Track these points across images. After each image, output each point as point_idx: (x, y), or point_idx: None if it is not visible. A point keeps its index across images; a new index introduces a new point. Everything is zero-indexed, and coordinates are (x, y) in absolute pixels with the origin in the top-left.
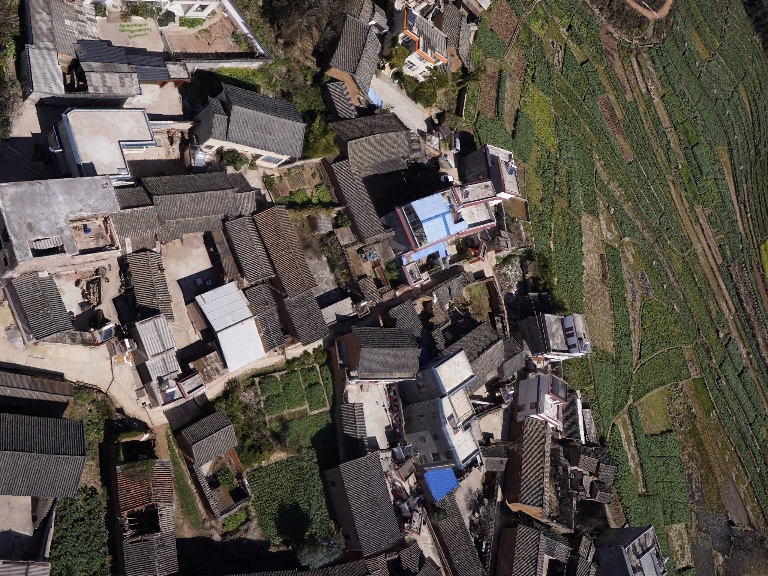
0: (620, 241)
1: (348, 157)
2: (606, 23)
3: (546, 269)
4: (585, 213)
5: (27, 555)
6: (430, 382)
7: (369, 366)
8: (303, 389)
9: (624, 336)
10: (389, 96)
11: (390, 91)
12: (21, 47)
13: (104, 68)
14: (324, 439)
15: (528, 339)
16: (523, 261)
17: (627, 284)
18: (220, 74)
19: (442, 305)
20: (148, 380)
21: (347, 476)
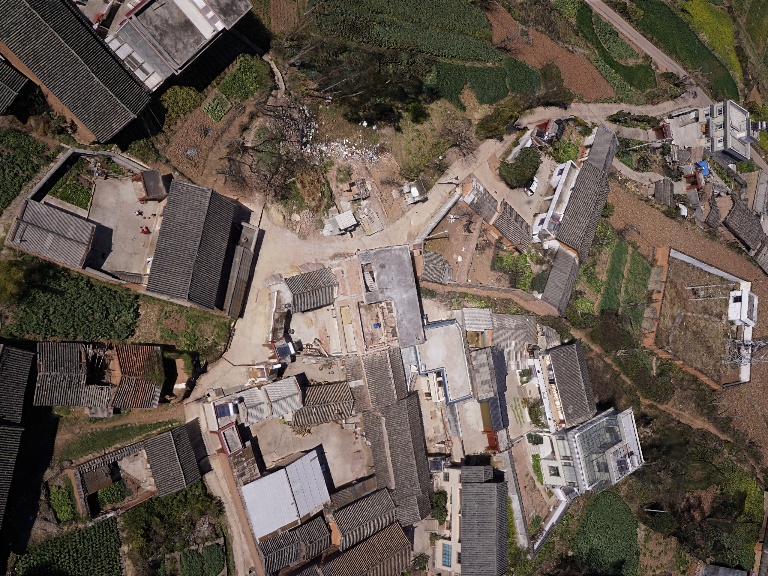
0: None
1: None
2: None
3: None
4: None
5: (85, 261)
6: None
7: None
8: None
9: None
10: None
11: None
12: None
13: (491, 367)
14: None
15: None
16: None
17: None
18: None
19: None
20: None
21: None
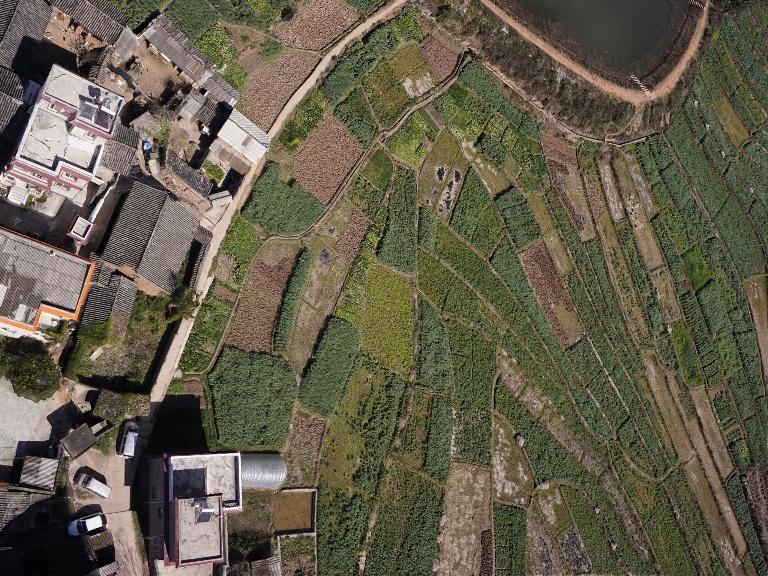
0: (532, 491)
1: None
2: (555, 121)
3: None
4: (461, 464)
5: None
6: None
7: None
8: None
9: None
10: None
11: None
12: None
13: None
14: None
15: None
16: None
17: (535, 566)
18: None
19: None
20: None
21: None
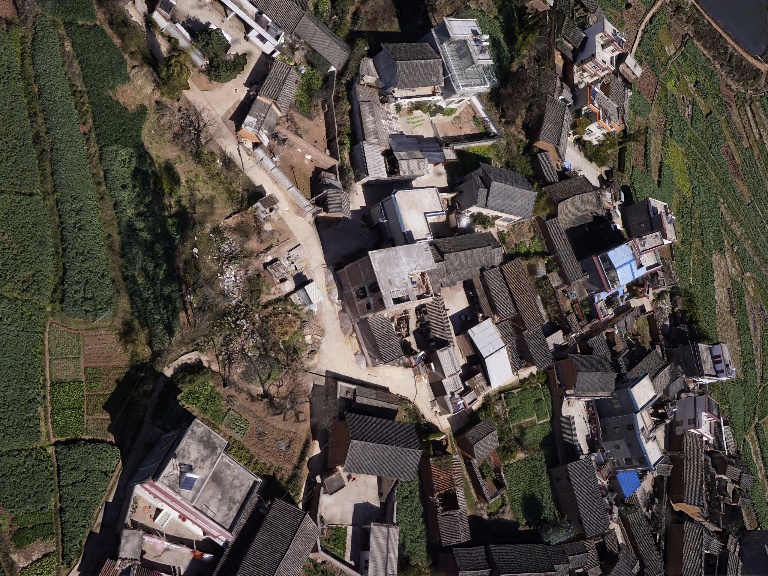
0: (742, 276)
1: (558, 215)
2: (726, 77)
3: (692, 303)
4: (714, 251)
5: (378, 521)
6: (624, 400)
7: (582, 386)
8: (532, 403)
9: (749, 362)
10: (572, 158)
11: (573, 154)
12: (352, 141)
13: (408, 156)
14: (548, 444)
15: (682, 364)
16: (672, 296)
17: (749, 315)
18: (468, 151)
19: (622, 336)
20: (441, 394)
21: (572, 474)
